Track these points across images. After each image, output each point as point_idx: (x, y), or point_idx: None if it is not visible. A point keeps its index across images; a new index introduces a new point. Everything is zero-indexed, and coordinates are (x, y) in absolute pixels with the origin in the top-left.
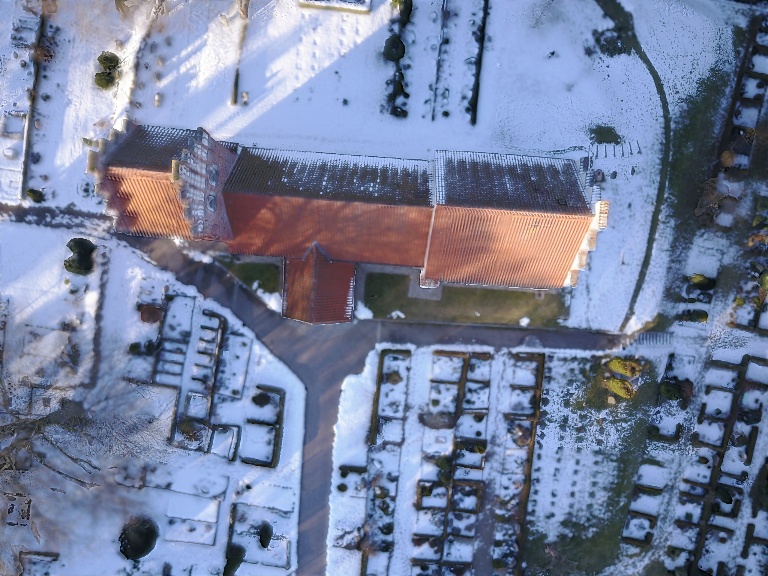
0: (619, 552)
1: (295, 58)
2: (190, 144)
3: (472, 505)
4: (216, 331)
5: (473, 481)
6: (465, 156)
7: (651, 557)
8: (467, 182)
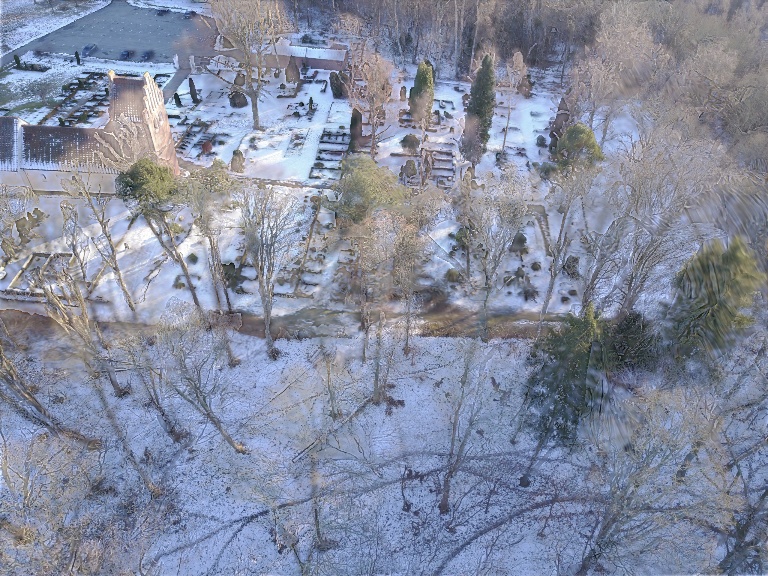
0: (15, 107)
1: (91, 235)
2: (110, 96)
3: (77, 113)
4: (177, 147)
5: (72, 117)
6: (1, 166)
7: (0, 107)
8: (2, 140)
